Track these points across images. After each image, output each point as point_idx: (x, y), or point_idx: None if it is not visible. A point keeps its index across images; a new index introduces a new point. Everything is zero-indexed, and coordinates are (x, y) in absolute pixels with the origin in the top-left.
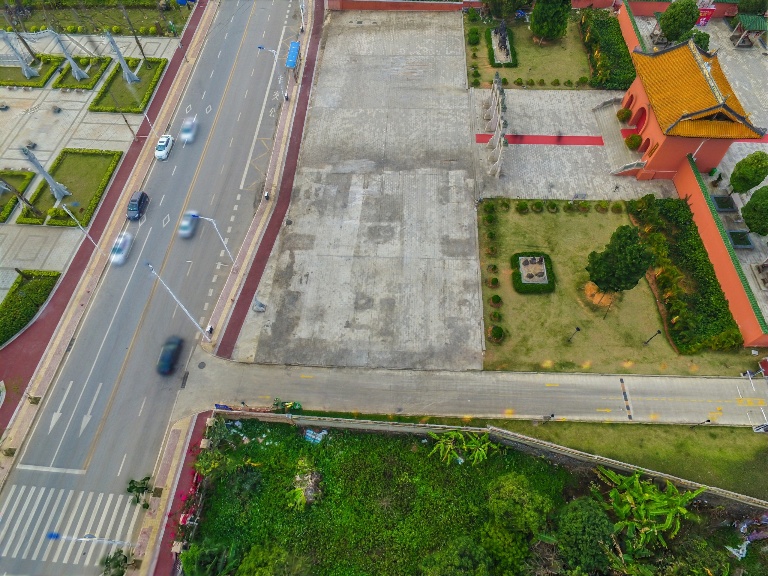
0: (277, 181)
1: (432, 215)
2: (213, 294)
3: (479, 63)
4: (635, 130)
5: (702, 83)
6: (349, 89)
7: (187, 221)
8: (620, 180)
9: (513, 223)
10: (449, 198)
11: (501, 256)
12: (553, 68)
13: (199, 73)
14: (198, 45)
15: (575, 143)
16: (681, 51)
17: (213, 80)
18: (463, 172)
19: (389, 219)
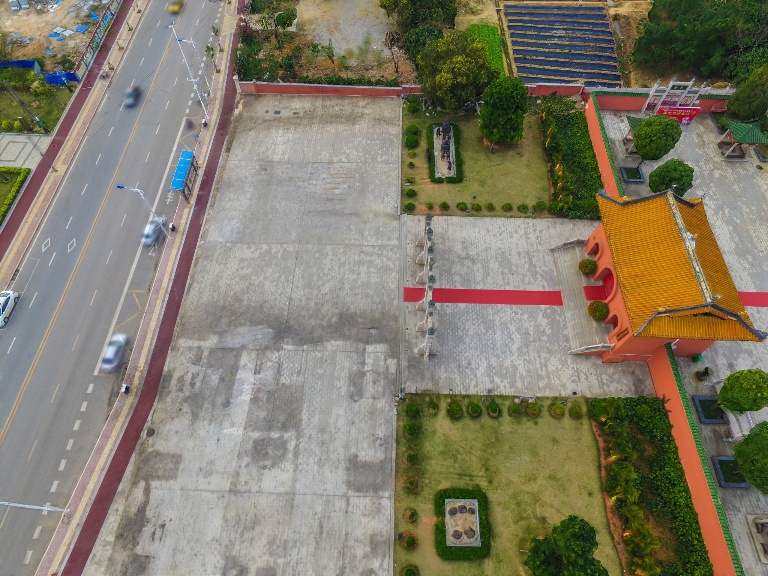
0: (144, 362)
1: (339, 420)
2: (31, 560)
3: (416, 175)
4: (601, 288)
5: (684, 261)
6: (253, 213)
7: (15, 432)
8: (581, 363)
9: (442, 435)
10: (363, 391)
11: (423, 492)
12: (505, 184)
13: (68, 188)
14: (73, 146)
15: (527, 302)
16: (658, 204)
17: (84, 199)
18: (384, 348)
19: (282, 427)
